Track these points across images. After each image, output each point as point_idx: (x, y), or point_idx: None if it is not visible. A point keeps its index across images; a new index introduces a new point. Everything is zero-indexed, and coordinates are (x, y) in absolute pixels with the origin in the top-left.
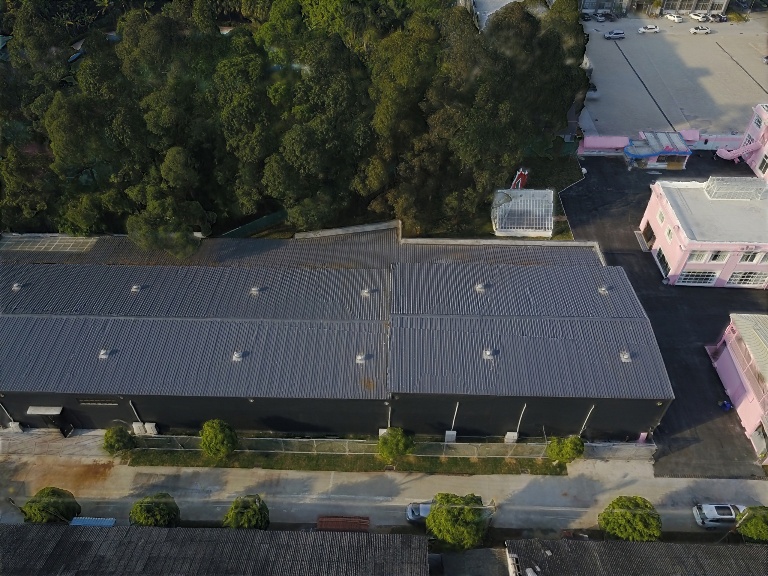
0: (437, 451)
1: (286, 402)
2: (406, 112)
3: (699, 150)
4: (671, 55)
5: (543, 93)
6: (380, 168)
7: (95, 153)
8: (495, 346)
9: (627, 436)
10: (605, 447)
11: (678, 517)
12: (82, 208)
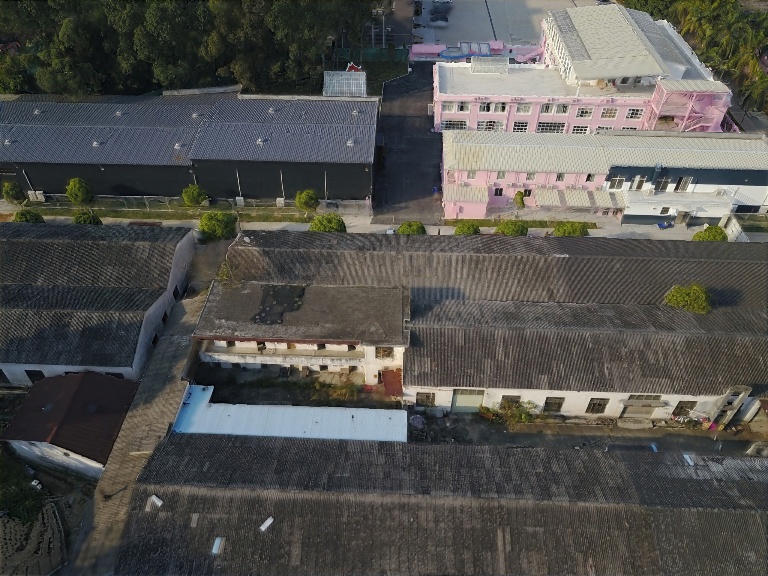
0: (230, 210)
1: (125, 171)
2: None
3: None
4: None
5: None
6: (216, 38)
7: (13, 22)
8: (267, 137)
9: None
10: None
11: None
12: (6, 65)
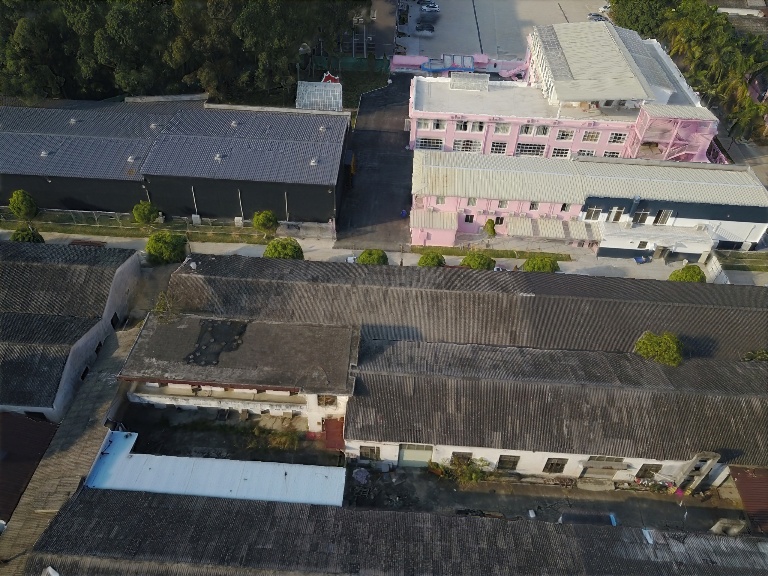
0: (185, 228)
1: (74, 183)
2: (202, 3)
3: (491, 72)
4: (514, 10)
5: None
6: (181, 44)
7: None
8: (226, 153)
9: None
10: (299, 226)
11: None
12: None
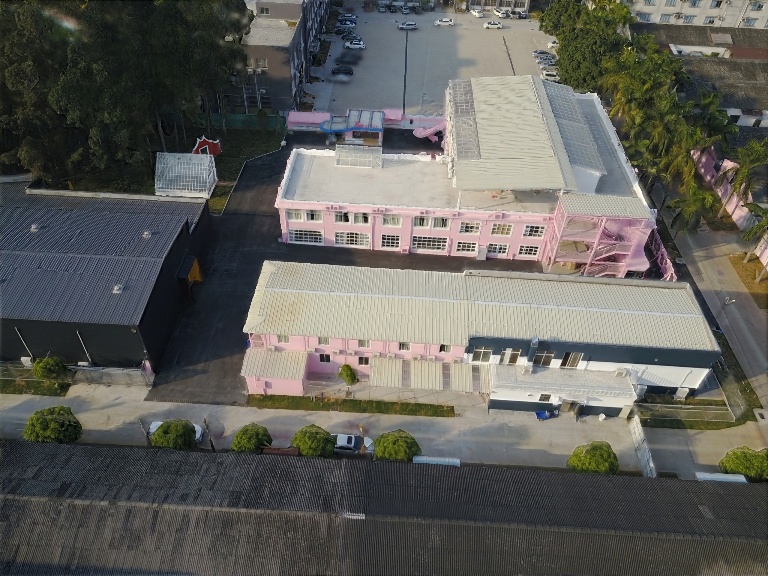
0: None
1: None
2: None
3: (407, 130)
4: (450, 46)
5: (148, 56)
6: None
7: None
8: (5, 276)
9: (134, 365)
10: None
11: (138, 433)
12: None
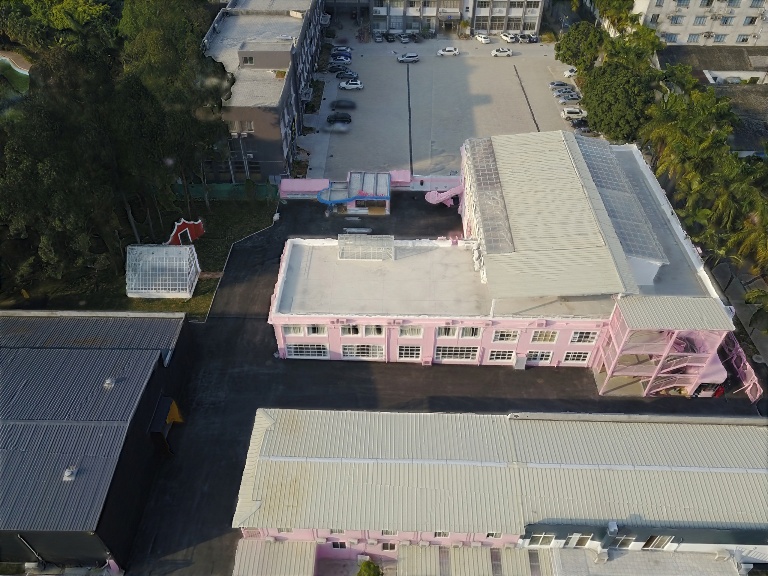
0: None
1: None
2: None
3: (417, 191)
4: (457, 80)
5: (106, 148)
6: None
7: None
8: None
9: (96, 561)
10: None
11: None
12: None
